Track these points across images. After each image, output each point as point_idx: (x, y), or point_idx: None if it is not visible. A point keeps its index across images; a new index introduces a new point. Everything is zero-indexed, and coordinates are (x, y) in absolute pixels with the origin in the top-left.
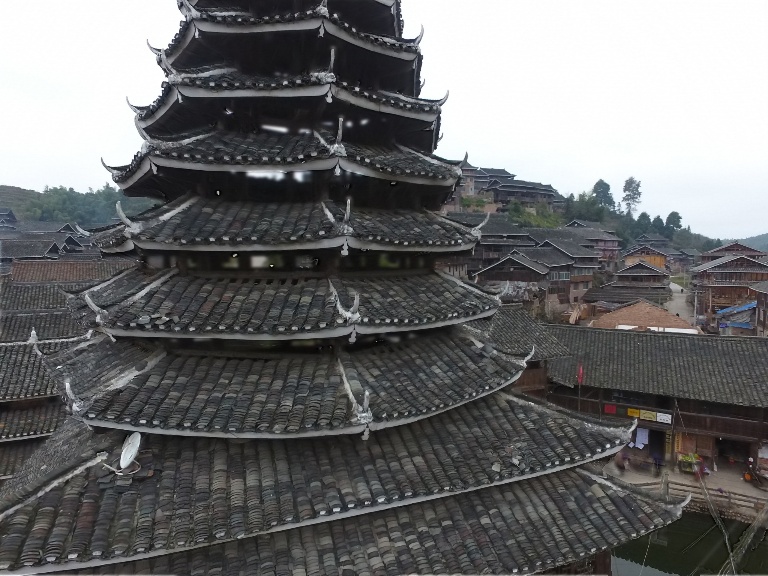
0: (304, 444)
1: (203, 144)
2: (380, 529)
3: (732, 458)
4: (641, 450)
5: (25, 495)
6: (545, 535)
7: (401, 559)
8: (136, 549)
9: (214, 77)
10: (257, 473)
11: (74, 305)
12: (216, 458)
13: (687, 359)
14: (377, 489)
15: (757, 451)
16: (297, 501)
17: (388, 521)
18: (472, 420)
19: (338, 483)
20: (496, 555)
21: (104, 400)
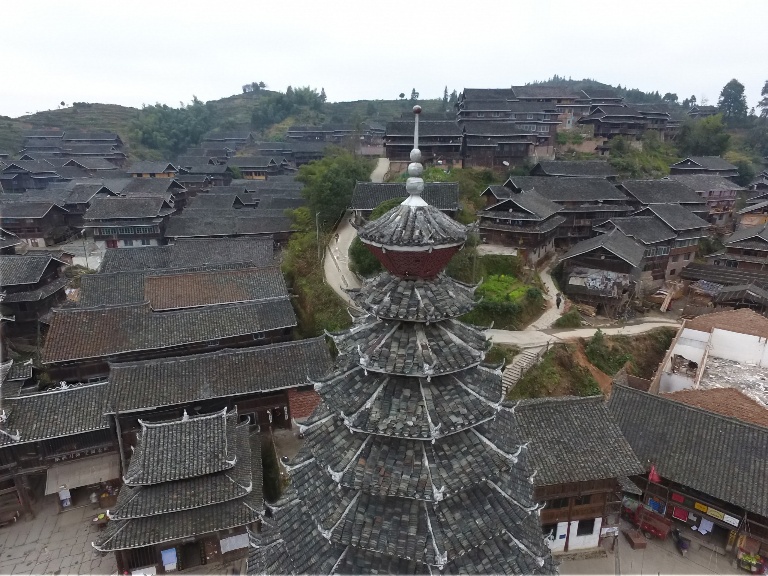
0: None
1: (346, 571)
2: None
3: None
4: (703, 535)
5: None
6: None
7: None
8: None
9: (352, 516)
10: None
11: None
12: None
13: None
14: None
15: None
16: None
17: None
18: None
19: None
20: None
21: None
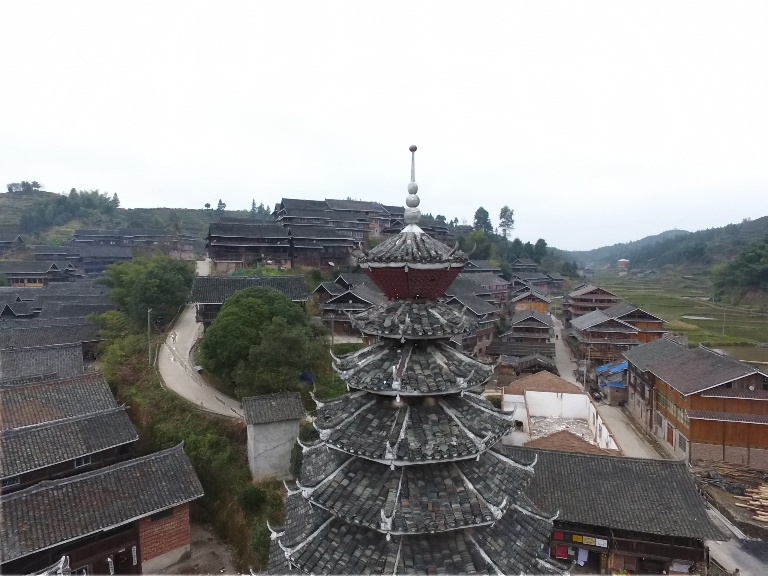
0: None
1: None
2: None
3: (650, 570)
4: (582, 567)
5: None
6: None
7: None
8: None
9: (404, 573)
10: None
11: None
12: None
13: (613, 484)
14: None
15: (669, 566)
16: None
17: None
18: None
19: None
20: None
21: None
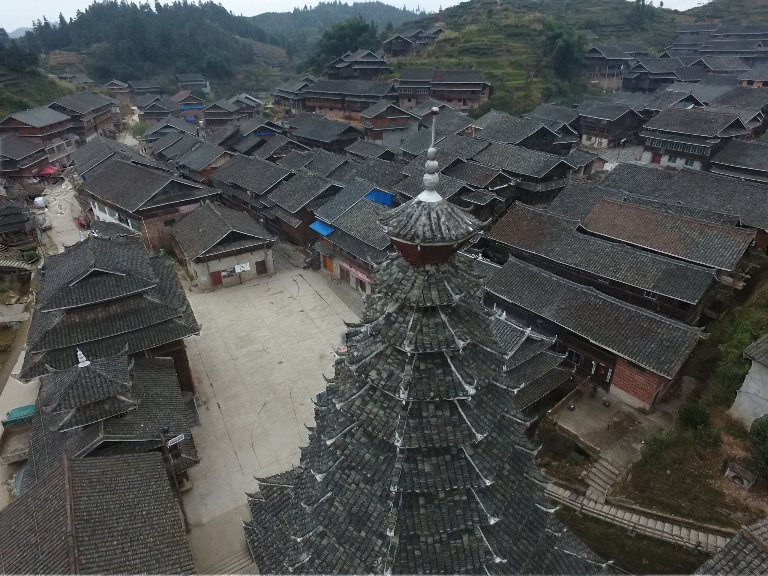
0: None
1: None
2: None
3: None
4: None
5: None
6: None
7: None
8: None
9: None
10: None
11: None
12: None
13: None
14: None
15: None
16: None
17: None
18: None
19: None
20: None
21: (298, 475)
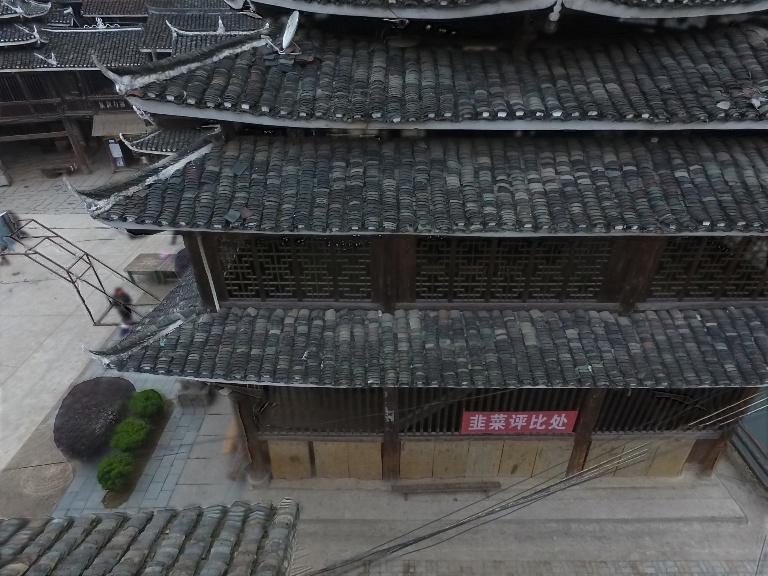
0: (472, 57)
1: None
2: (547, 160)
3: None
4: None
5: (202, 54)
6: (761, 201)
7: (565, 190)
8: (299, 113)
9: None
10: (417, 74)
11: None
12: (375, 57)
13: None
14: (554, 104)
15: None
16: (458, 102)
17: (557, 155)
18: (702, 56)
19: (507, 95)
20: (685, 208)
21: None
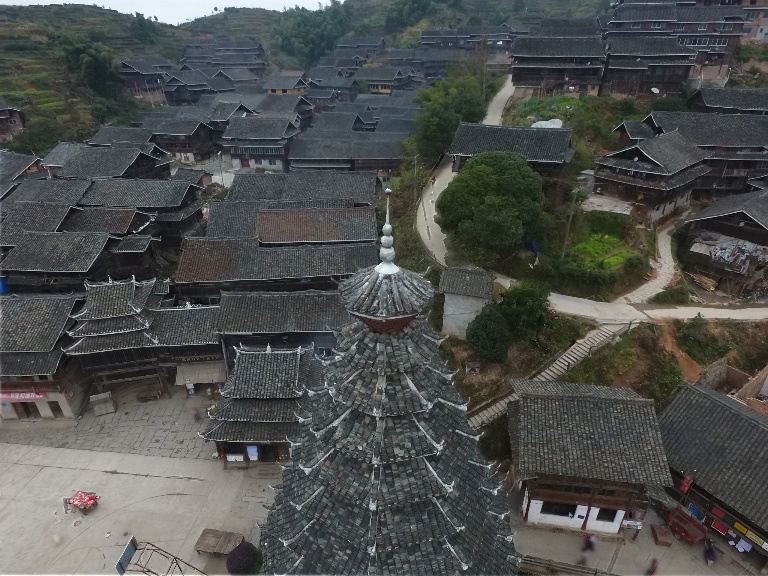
0: None
1: (313, 532)
2: None
3: None
4: (739, 552)
5: None
6: None
7: None
8: None
9: (319, 498)
10: None
11: (269, 524)
12: None
13: None
14: None
15: None
16: None
17: None
18: None
19: None
20: None
21: None
